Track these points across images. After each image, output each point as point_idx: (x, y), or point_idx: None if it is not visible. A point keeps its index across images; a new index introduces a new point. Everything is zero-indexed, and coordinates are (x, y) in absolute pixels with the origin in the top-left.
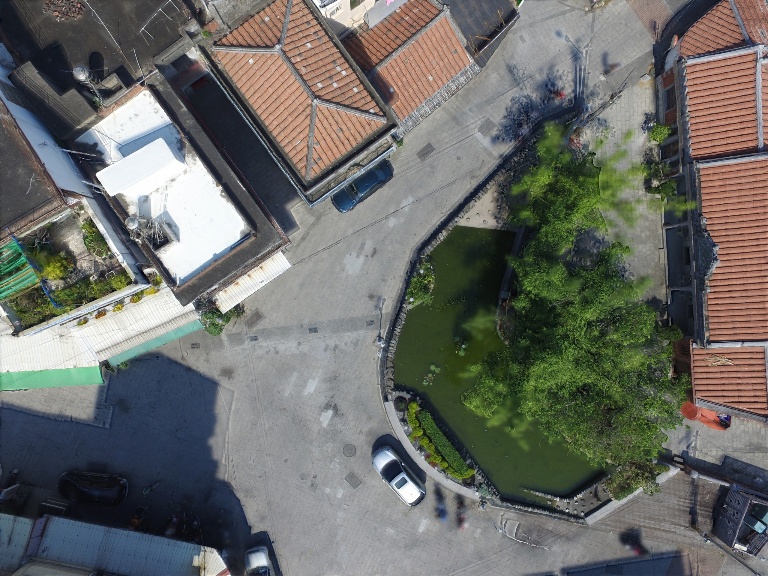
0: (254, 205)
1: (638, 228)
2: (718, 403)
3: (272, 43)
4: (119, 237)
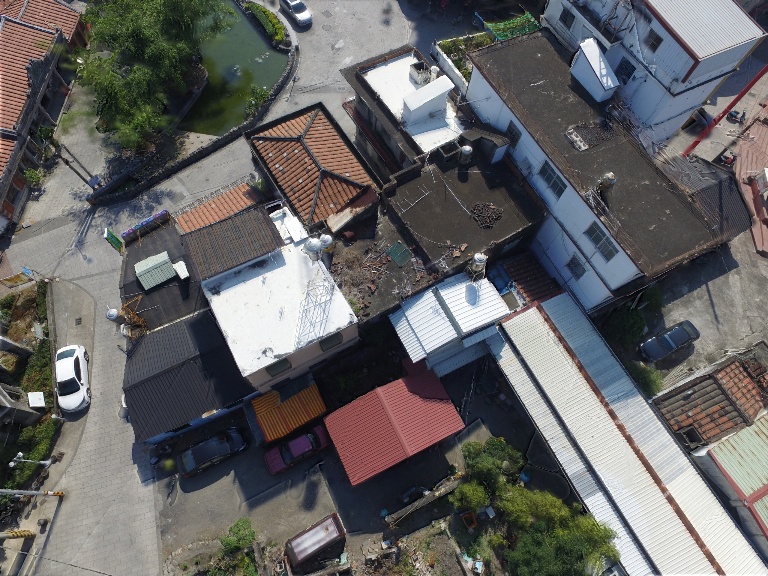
0: (356, 88)
1: (78, 128)
2: (65, 6)
3: (328, 180)
4: (449, 76)
